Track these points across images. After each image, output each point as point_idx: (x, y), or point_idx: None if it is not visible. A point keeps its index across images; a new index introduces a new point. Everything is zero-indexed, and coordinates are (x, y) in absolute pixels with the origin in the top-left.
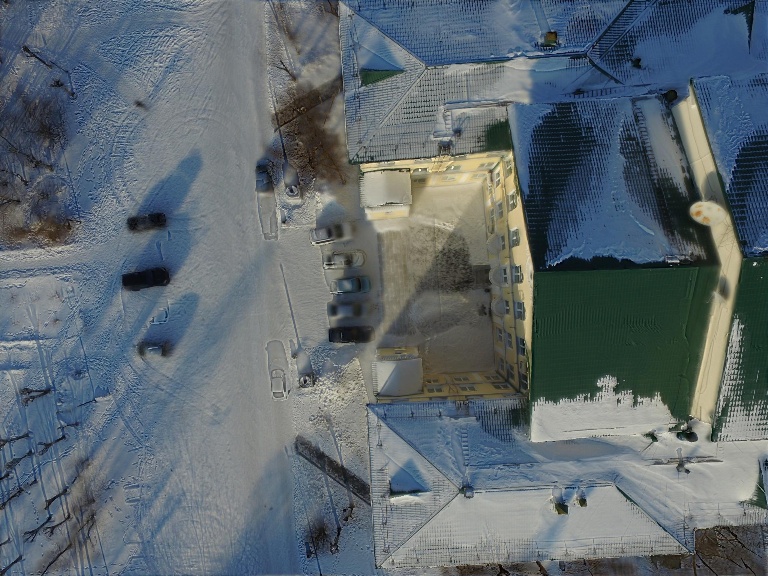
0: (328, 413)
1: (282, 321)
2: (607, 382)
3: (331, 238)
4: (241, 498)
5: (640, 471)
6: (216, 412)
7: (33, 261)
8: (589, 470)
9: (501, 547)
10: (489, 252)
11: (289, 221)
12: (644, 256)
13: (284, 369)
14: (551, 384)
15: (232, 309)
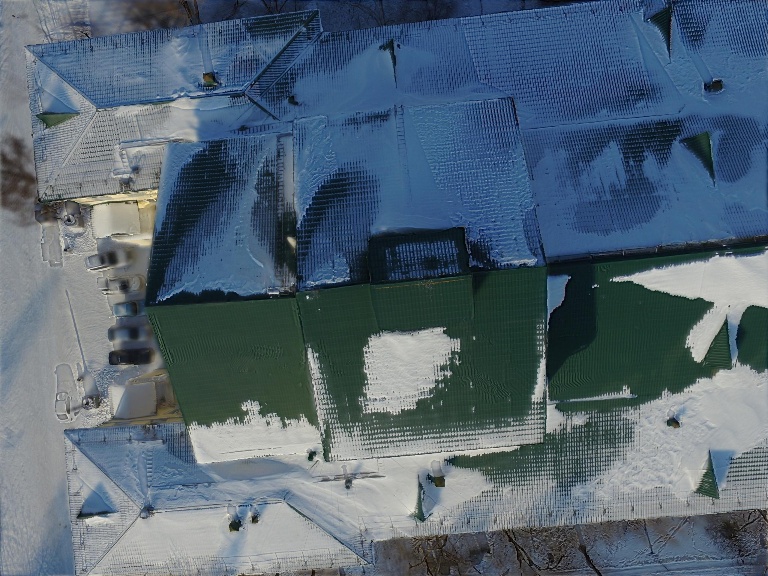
0: None
1: (69, 345)
2: (250, 406)
3: (104, 265)
4: (36, 517)
5: (310, 488)
6: (9, 435)
7: None
8: (261, 488)
9: (190, 563)
10: None
11: (72, 249)
12: (249, 289)
13: (69, 392)
14: (198, 409)
15: (21, 335)
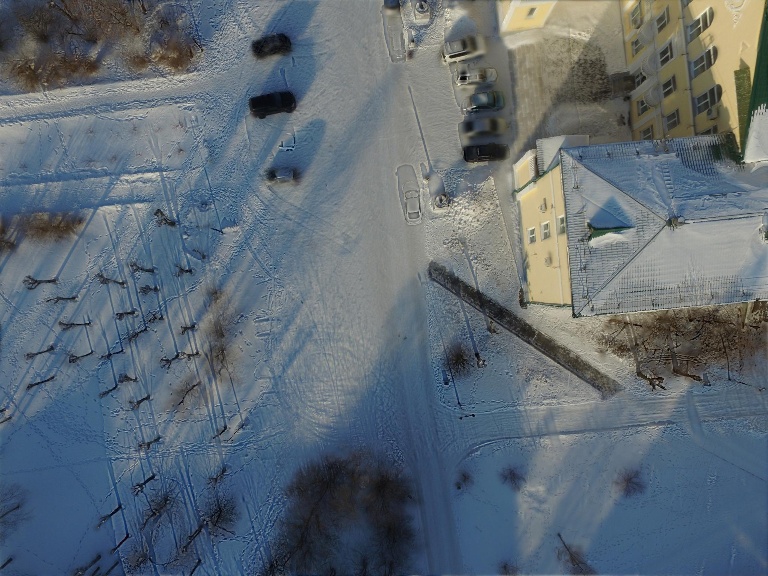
0: (463, 236)
1: (412, 145)
2: None
3: (466, 50)
4: (374, 328)
5: None
6: (346, 240)
7: (154, 91)
8: None
9: (705, 286)
10: (629, 56)
11: (417, 42)
12: None
13: (418, 190)
14: None
15: (360, 134)
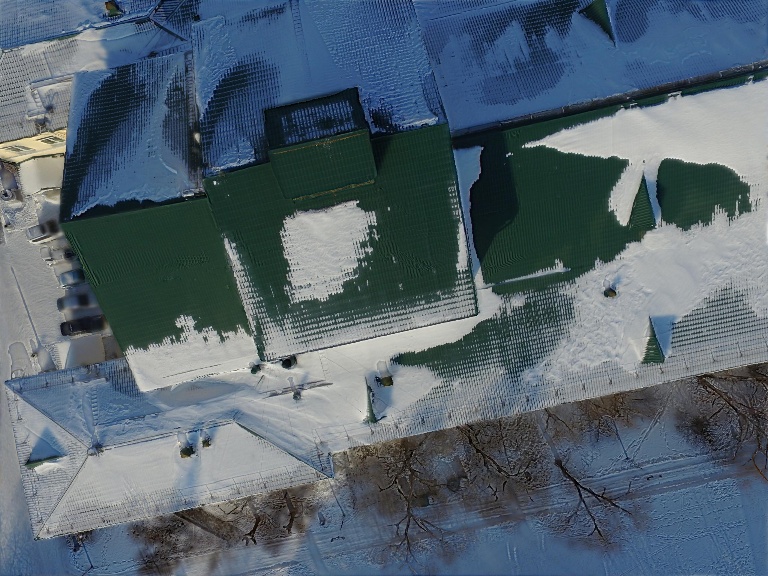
0: None
1: (20, 323)
2: (184, 322)
3: (45, 234)
4: (4, 502)
5: (259, 405)
6: None
7: None
8: (209, 411)
9: (147, 500)
10: None
11: (13, 225)
12: (163, 194)
13: (24, 369)
14: (132, 332)
15: None
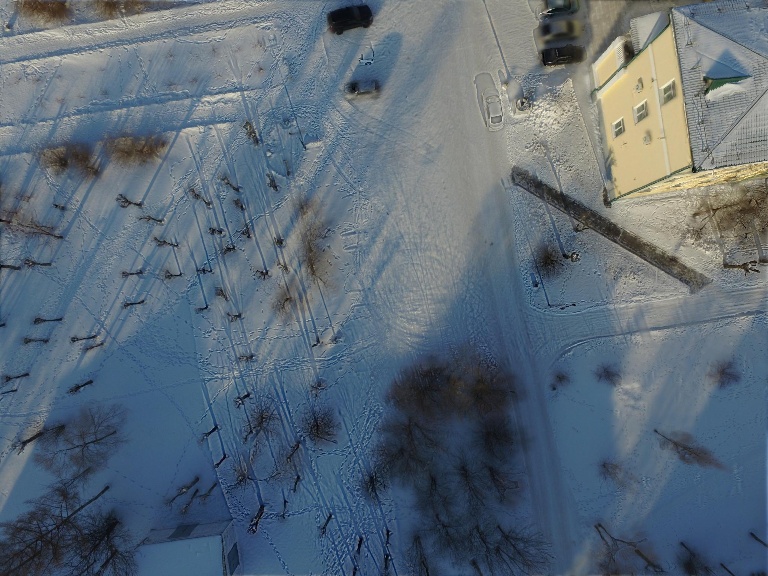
0: (544, 139)
1: (489, 53)
2: None
3: None
4: (460, 236)
5: None
6: (429, 150)
7: (231, 13)
8: None
9: None
10: None
11: None
12: None
13: (498, 95)
14: None
15: (437, 45)
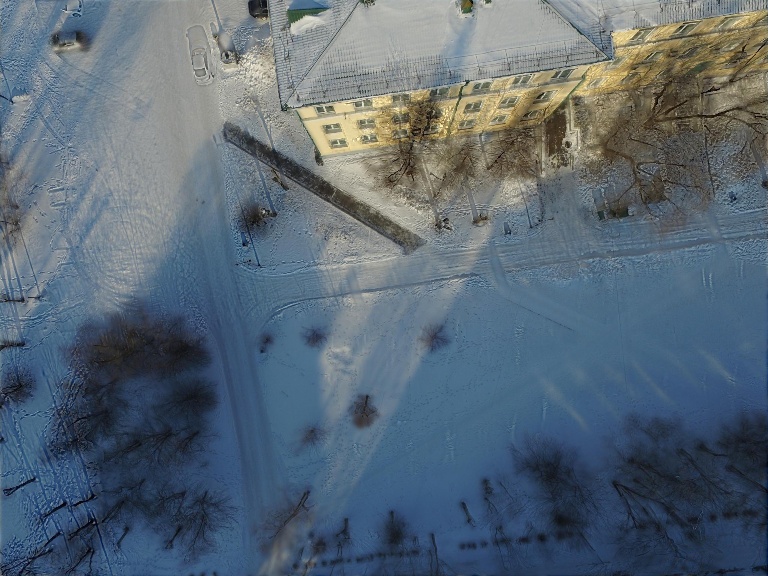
0: (255, 94)
1: (201, 5)
2: None
3: None
4: (171, 193)
5: None
6: (139, 105)
7: None
8: None
9: (410, 69)
10: None
11: None
12: None
13: (205, 48)
14: None
15: None
